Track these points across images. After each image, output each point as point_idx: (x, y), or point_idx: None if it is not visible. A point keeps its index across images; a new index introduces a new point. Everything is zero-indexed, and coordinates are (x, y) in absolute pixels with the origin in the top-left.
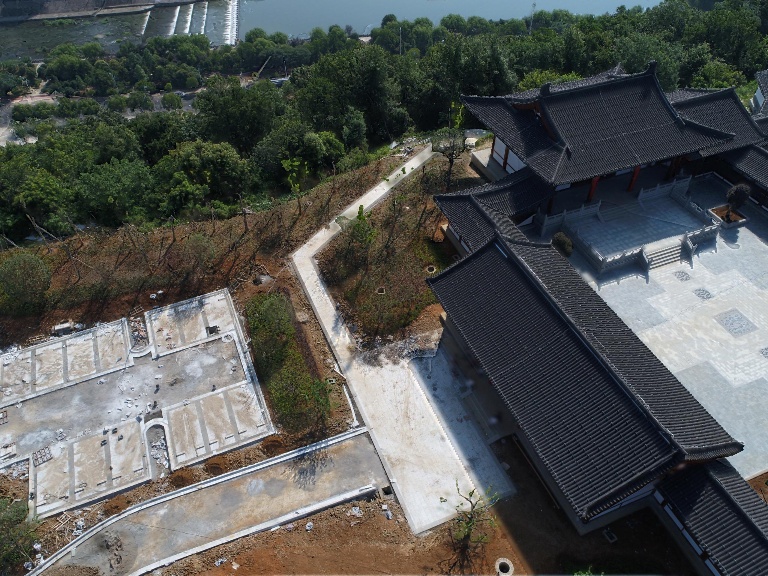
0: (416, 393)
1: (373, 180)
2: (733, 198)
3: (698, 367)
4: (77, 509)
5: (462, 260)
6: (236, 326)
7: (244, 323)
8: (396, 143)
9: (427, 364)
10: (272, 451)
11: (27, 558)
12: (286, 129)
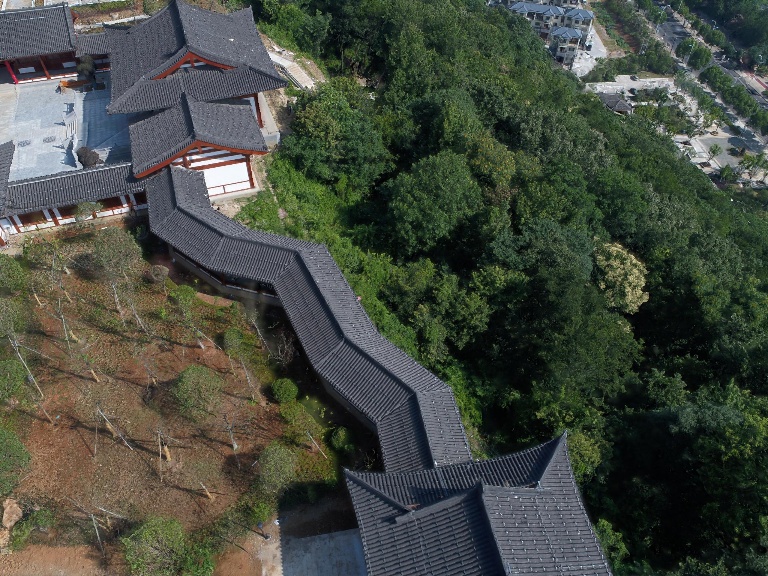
0: None
1: None
2: None
3: None
4: None
5: None
6: (120, 0)
7: None
8: (372, 93)
9: None
10: None
11: None
12: None
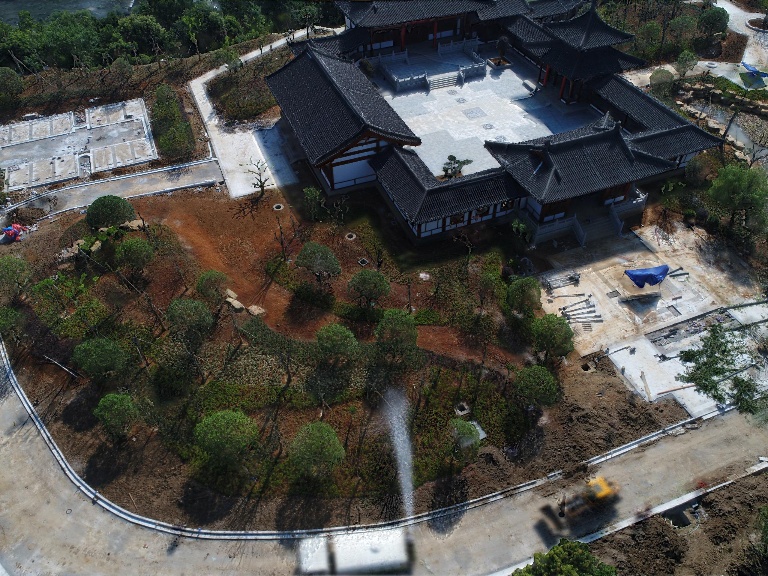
0: (253, 144)
1: (258, 45)
2: (498, 47)
3: (438, 132)
4: (33, 188)
5: (286, 64)
6: (144, 115)
7: (150, 114)
8: None
9: (264, 132)
10: (155, 166)
11: (2, 203)
12: (196, 9)
